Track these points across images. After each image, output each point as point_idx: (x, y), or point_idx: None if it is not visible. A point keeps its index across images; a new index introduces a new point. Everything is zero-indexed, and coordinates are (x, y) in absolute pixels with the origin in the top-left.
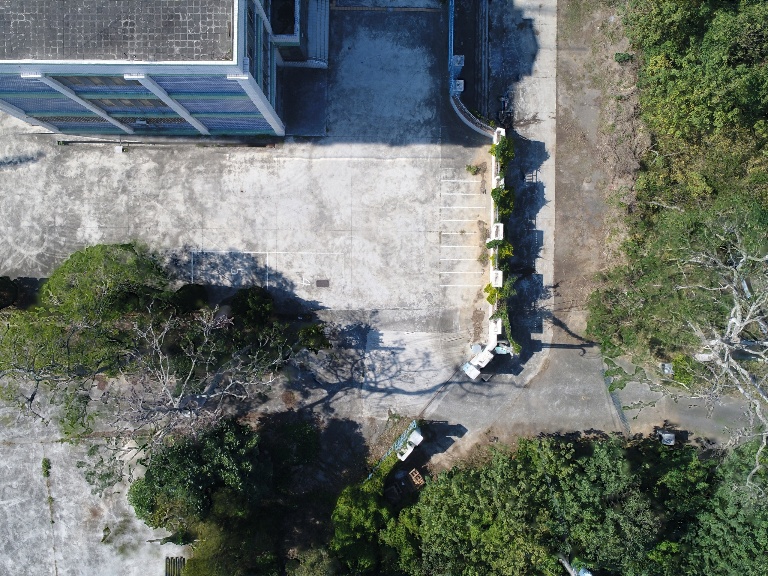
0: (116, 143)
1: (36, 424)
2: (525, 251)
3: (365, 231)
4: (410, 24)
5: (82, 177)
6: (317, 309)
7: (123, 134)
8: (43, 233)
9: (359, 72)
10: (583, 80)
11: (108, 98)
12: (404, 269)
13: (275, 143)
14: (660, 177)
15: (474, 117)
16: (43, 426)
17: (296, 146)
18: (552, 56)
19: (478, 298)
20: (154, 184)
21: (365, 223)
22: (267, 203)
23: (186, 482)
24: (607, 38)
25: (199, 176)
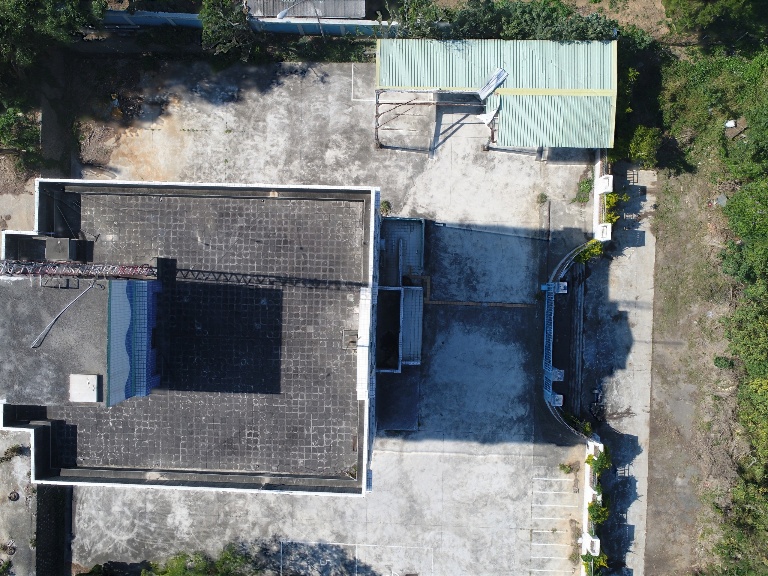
0: None
1: None
2: (615, 545)
3: (455, 527)
4: (505, 320)
5: None
6: None
7: None
8: (134, 518)
9: (452, 367)
10: (679, 374)
11: None
12: (494, 565)
13: None
14: (760, 491)
15: (572, 430)
16: None
17: (387, 439)
18: (647, 349)
19: None
20: None
21: (455, 519)
22: None
23: None
24: (705, 335)
25: None
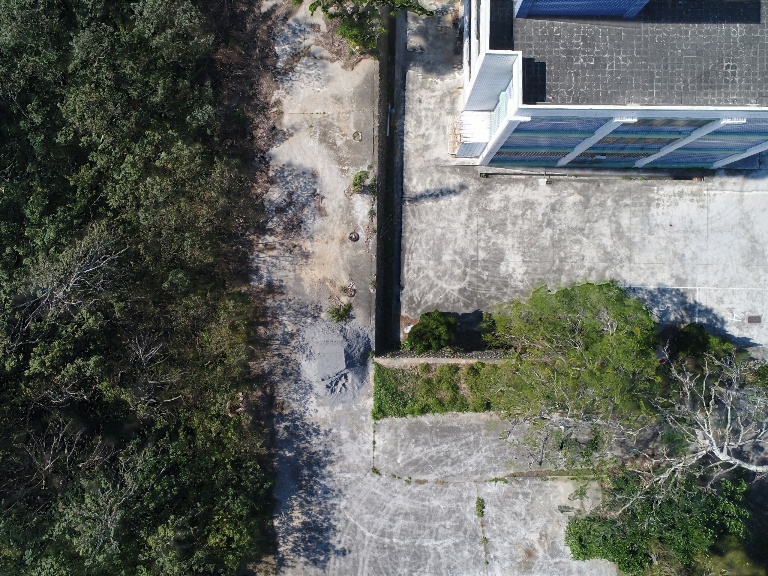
0: (537, 175)
1: (470, 463)
2: None
3: None
4: None
5: (505, 210)
6: (748, 346)
7: (548, 166)
8: (465, 267)
9: None
10: None
11: (628, 137)
12: None
13: (705, 176)
14: None
15: None
16: (477, 465)
17: (727, 179)
18: None
19: None
20: (580, 217)
21: None
22: (697, 237)
23: (707, 531)
24: None
25: (626, 209)
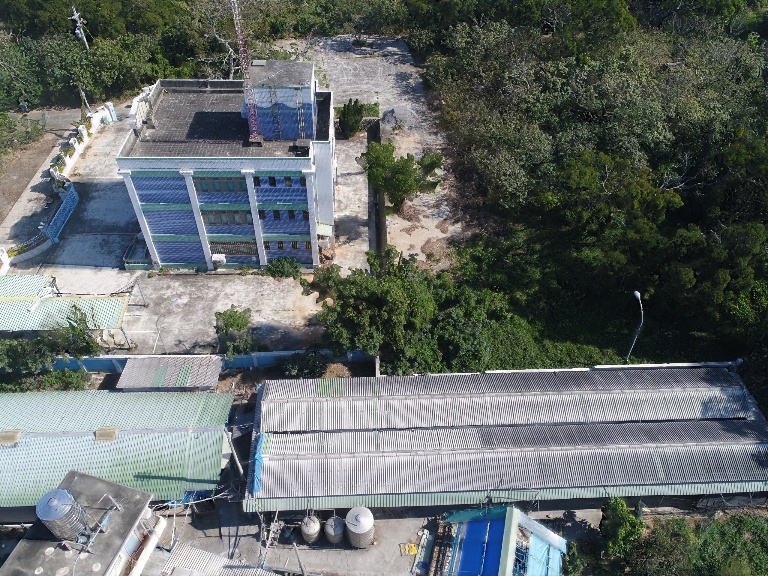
0: None
1: None
2: None
3: None
4: (89, 228)
5: None
6: None
7: None
8: None
9: (131, 209)
10: None
11: None
12: None
13: None
14: None
15: None
16: None
17: None
18: (4, 225)
19: (98, 137)
20: None
21: None
22: None
23: None
24: None
25: None
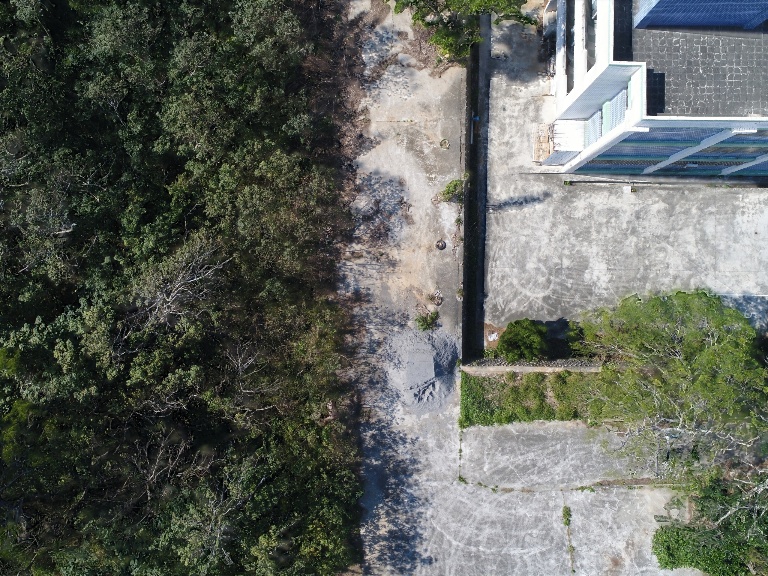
0: (621, 183)
1: (556, 471)
2: None
3: None
4: None
5: (590, 218)
6: None
7: (633, 174)
8: (550, 275)
9: None
10: None
11: None
12: None
13: None
14: None
15: None
16: (563, 473)
17: None
18: None
19: None
20: (664, 225)
21: None
22: None
23: None
24: None
25: (711, 217)
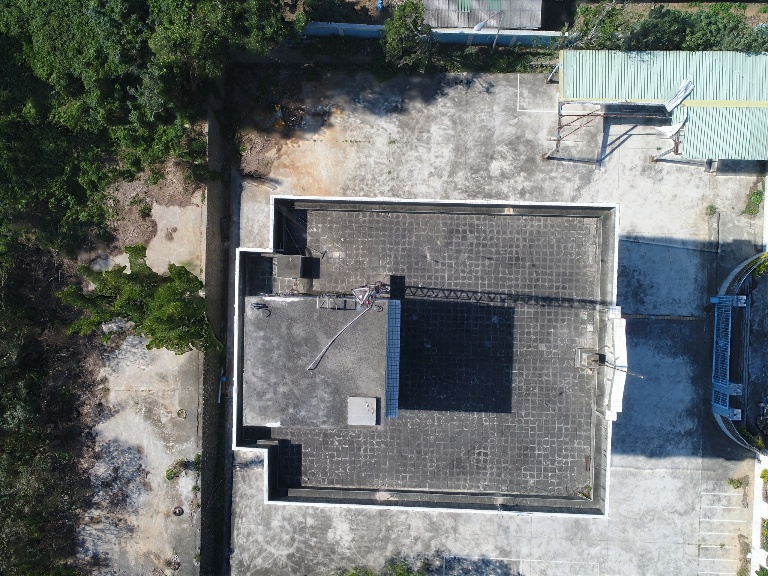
0: None
1: None
2: None
3: (622, 542)
4: (673, 333)
5: None
6: None
7: None
8: (294, 533)
9: None
10: None
11: None
12: None
13: None
14: None
15: (749, 445)
16: None
17: None
18: None
19: None
20: None
21: (622, 533)
22: None
23: None
24: None
25: None
